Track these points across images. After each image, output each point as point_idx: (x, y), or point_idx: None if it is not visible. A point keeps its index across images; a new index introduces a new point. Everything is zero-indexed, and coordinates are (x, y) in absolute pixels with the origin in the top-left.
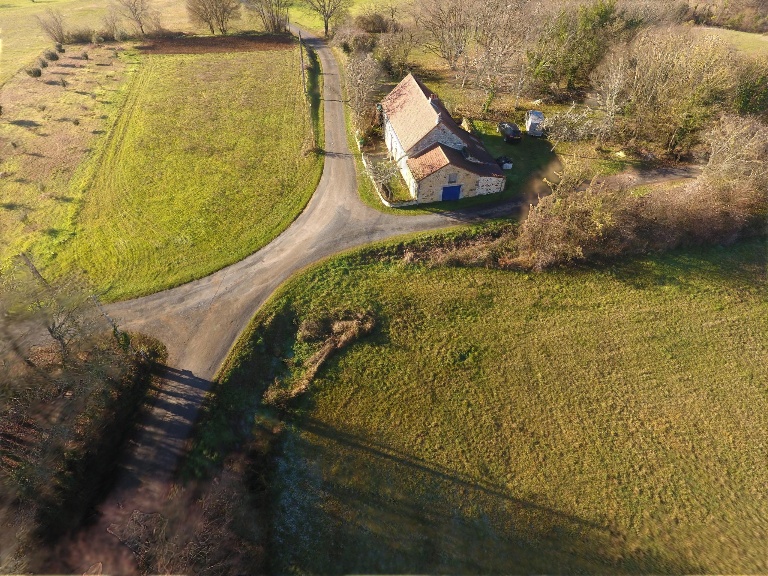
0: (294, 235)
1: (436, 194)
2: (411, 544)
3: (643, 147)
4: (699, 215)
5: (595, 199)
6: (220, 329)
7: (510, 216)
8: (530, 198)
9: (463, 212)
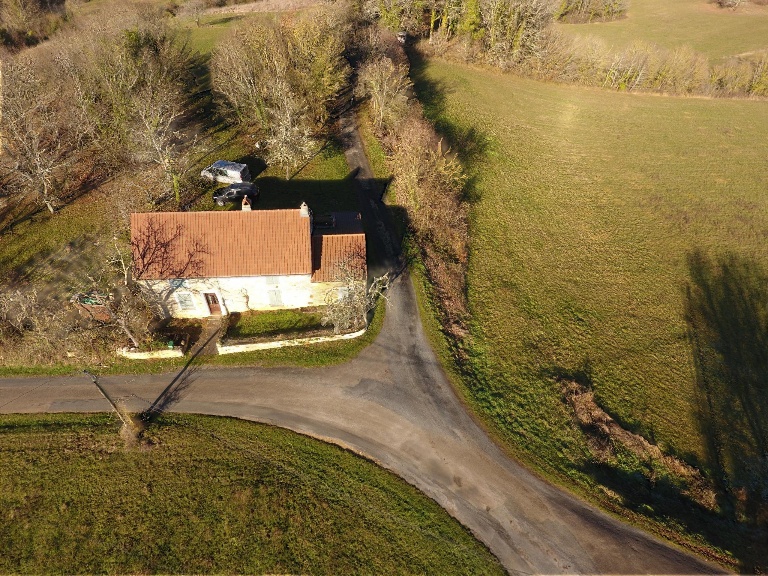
0: (417, 461)
1: None
2: (762, 396)
3: None
4: None
5: None
6: (654, 568)
7: (399, 235)
8: (372, 214)
9: (387, 267)
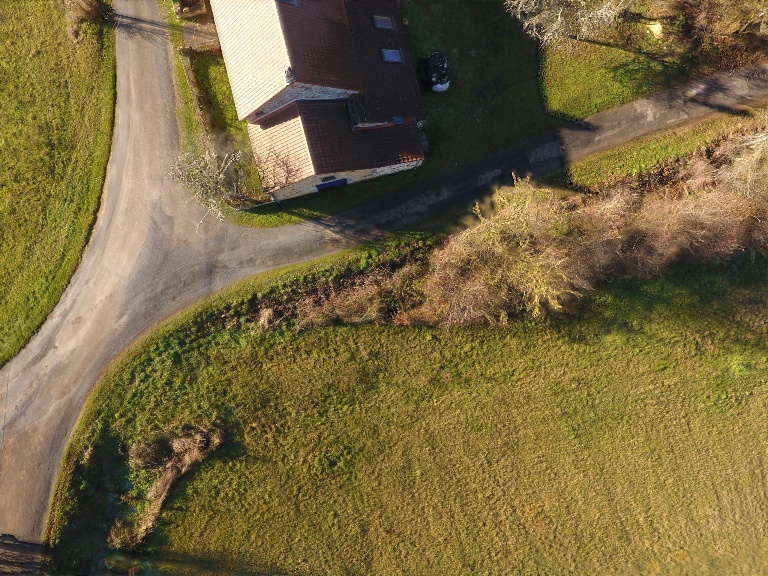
0: (91, 283)
1: (306, 190)
2: None
3: (705, 4)
4: (708, 232)
5: (541, 275)
6: (28, 477)
7: (423, 225)
8: (463, 178)
9: (351, 217)
